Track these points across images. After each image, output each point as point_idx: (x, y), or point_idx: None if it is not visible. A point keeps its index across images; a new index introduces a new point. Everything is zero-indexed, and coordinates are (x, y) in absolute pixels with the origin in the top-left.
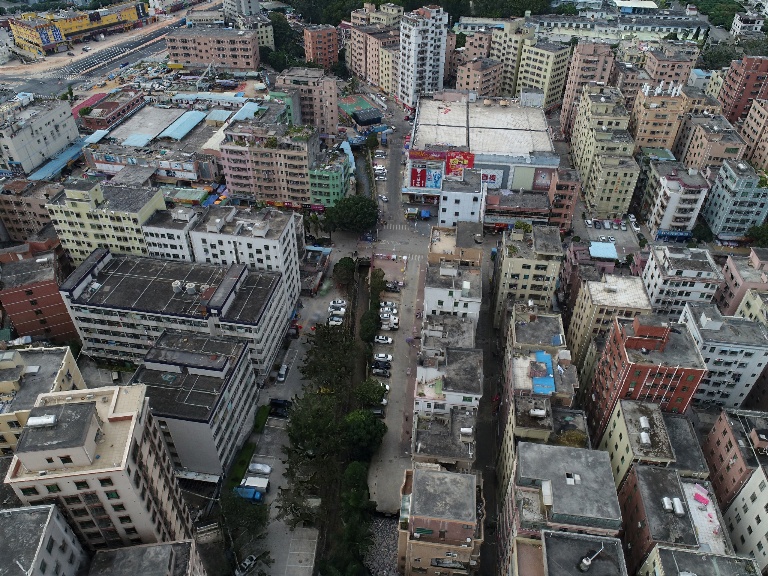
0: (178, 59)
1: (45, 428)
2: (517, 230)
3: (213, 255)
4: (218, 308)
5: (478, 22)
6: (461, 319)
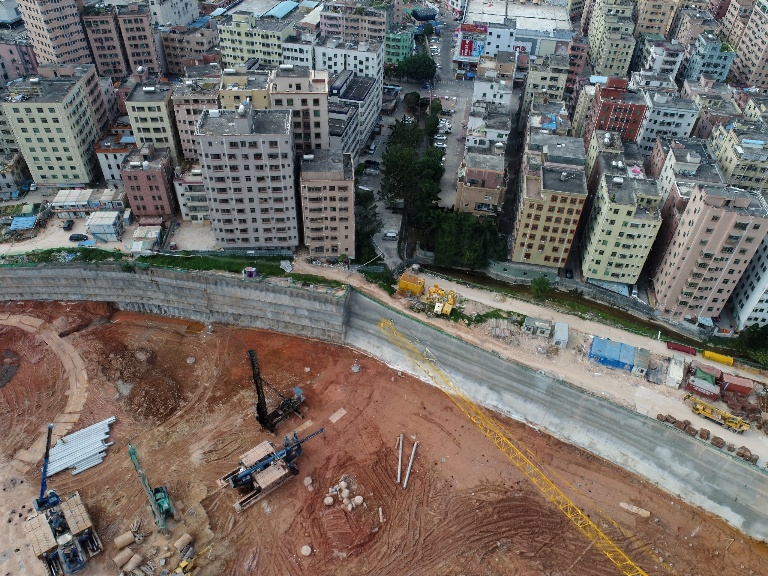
0: None
1: (287, 71)
2: None
3: (329, 66)
4: (338, 88)
5: None
6: (497, 105)
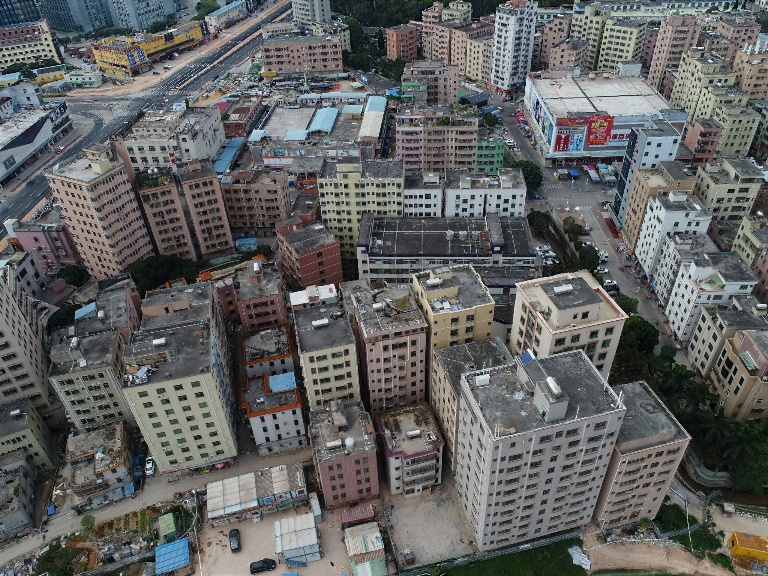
0: (271, 67)
1: (565, 294)
2: (712, 164)
3: (463, 209)
4: (502, 245)
5: None
6: (695, 236)
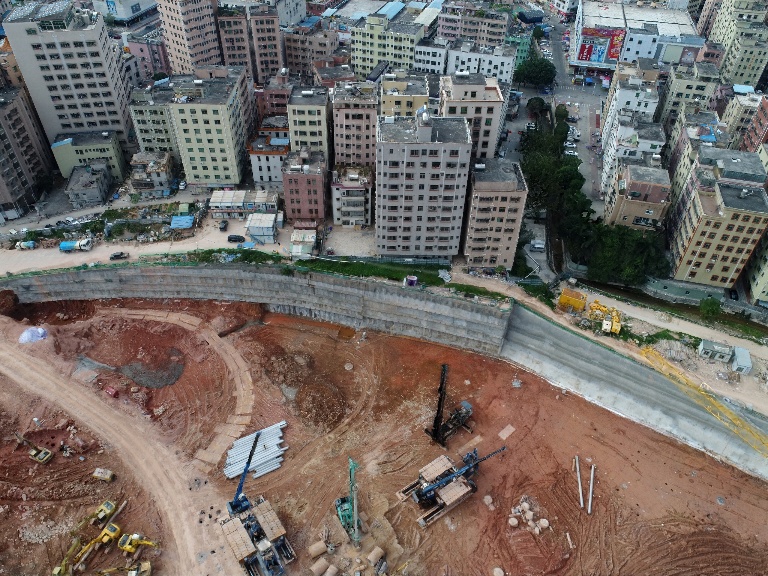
0: None
1: (463, 78)
2: None
3: (461, 70)
4: None
5: None
6: (642, 114)
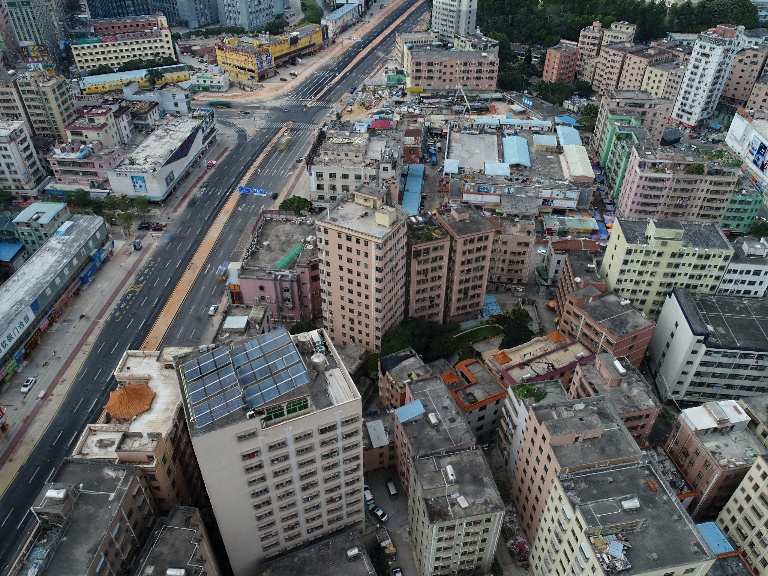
0: (419, 82)
1: None
2: None
3: None
4: None
5: (692, 38)
6: None
